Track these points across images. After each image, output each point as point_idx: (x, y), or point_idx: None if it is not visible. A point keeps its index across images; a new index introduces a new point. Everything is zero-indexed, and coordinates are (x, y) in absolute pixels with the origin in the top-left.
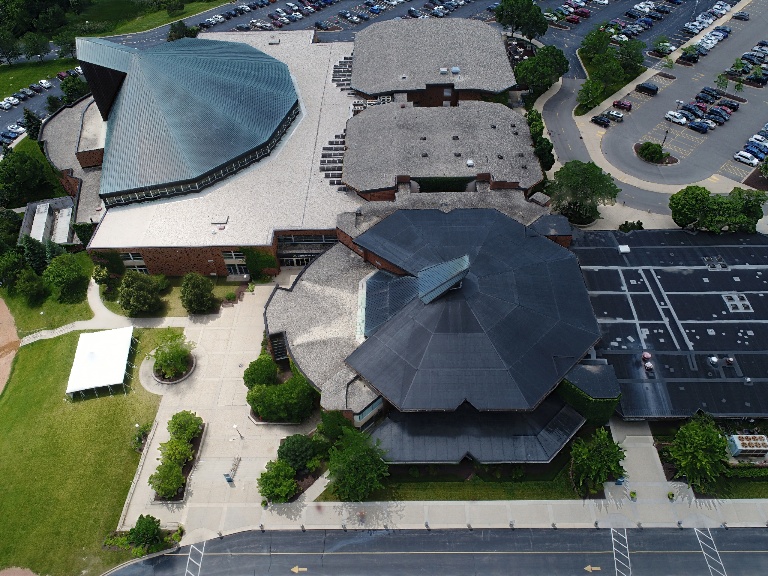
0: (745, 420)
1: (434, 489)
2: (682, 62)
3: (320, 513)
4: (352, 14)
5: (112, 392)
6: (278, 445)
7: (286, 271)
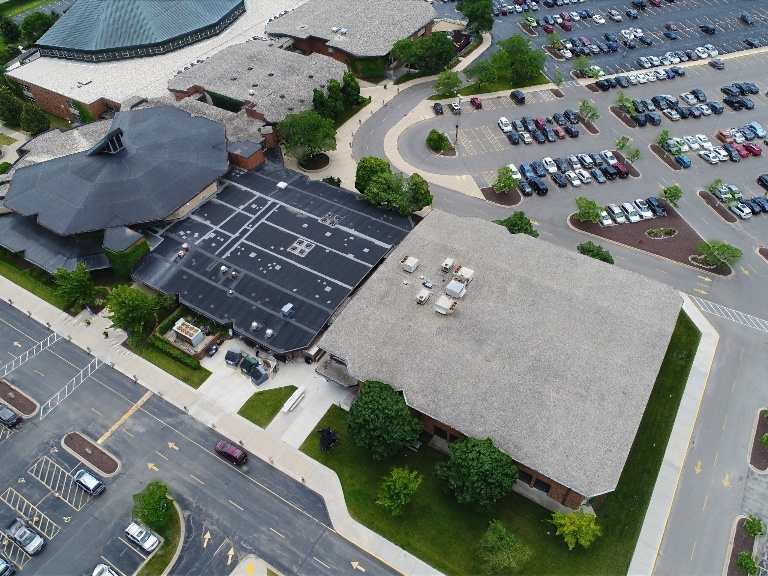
0: None
1: (3, 266)
2: (591, 86)
3: None
4: None
5: None
6: None
7: None
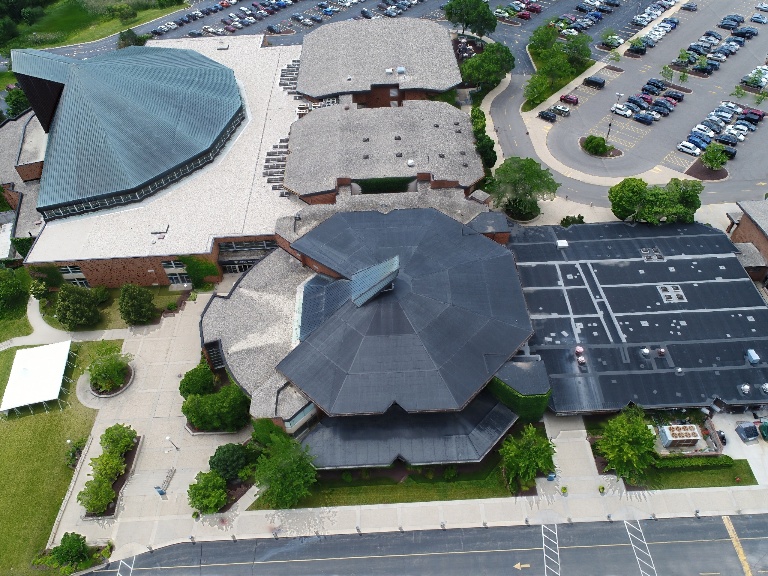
0: (677, 410)
1: (367, 493)
2: (630, 54)
3: (252, 522)
4: (305, 17)
5: (48, 408)
6: (213, 455)
7: (229, 278)
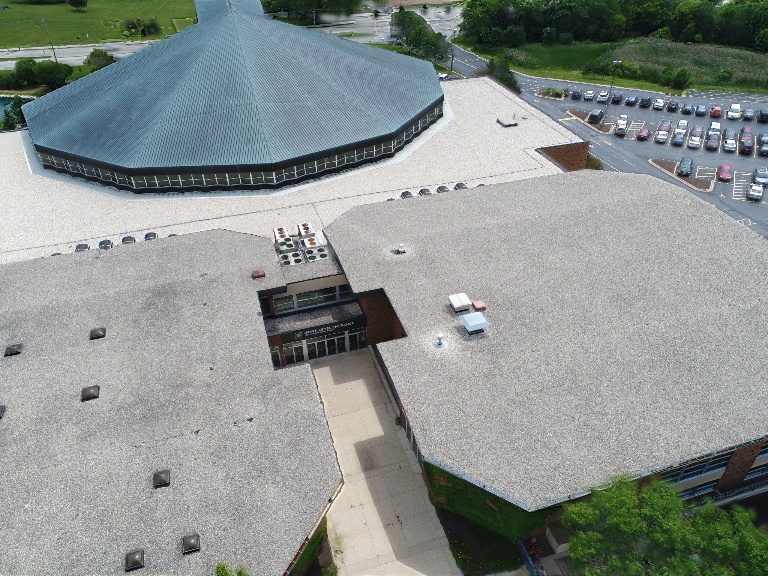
0: None
1: None
2: None
3: None
4: None
5: None
6: None
7: None
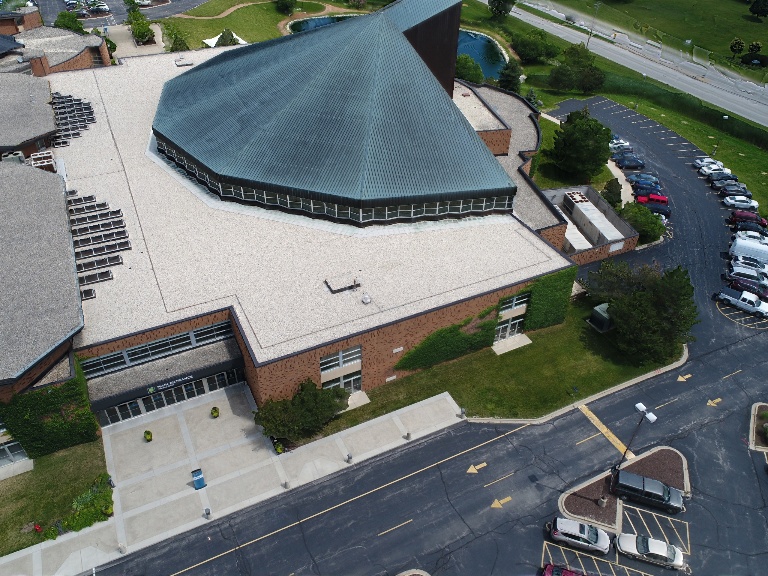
0: None
1: None
2: None
3: None
4: None
5: None
6: None
7: None
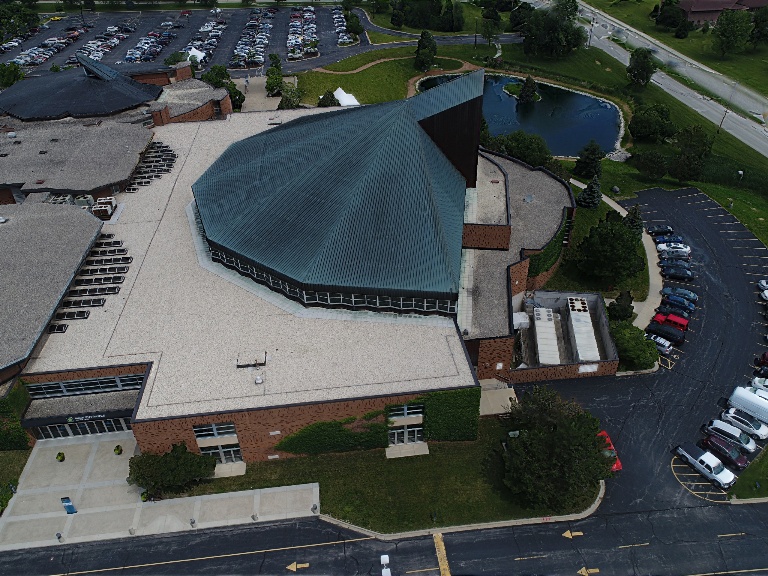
0: None
1: None
2: None
3: None
4: None
5: None
6: None
7: None
